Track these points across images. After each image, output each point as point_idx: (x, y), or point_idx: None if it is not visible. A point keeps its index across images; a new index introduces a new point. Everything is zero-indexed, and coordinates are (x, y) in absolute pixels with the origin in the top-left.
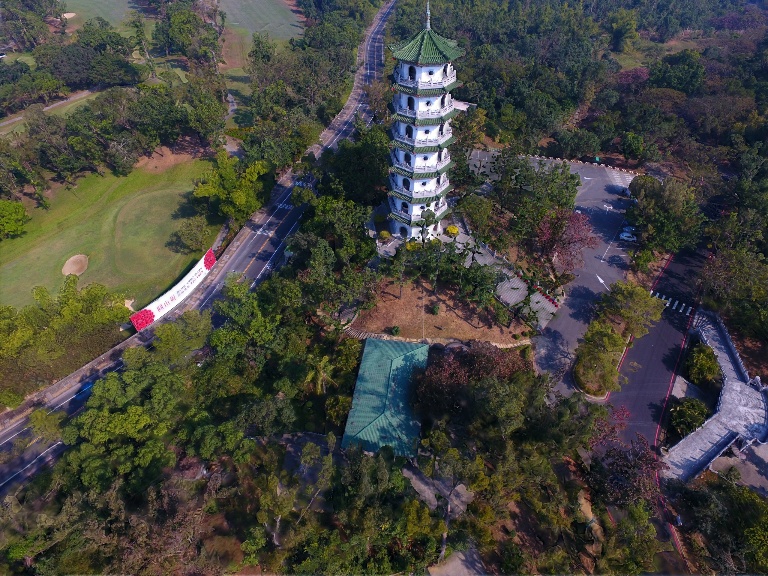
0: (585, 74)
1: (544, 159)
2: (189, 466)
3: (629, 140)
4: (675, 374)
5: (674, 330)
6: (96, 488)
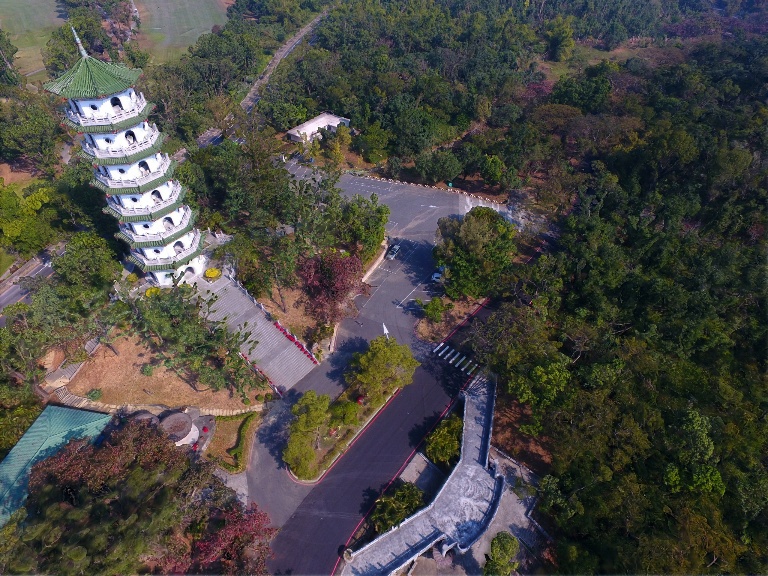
0: (479, 88)
1: (397, 183)
2: None
3: (486, 164)
4: (416, 450)
5: (443, 393)
6: None
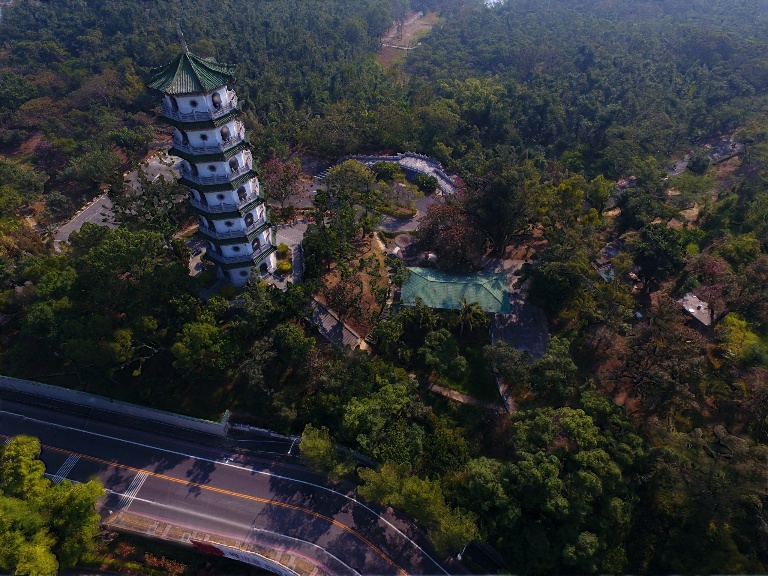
0: None
1: (103, 196)
2: None
3: (124, 135)
4: None
5: None
6: (641, 440)
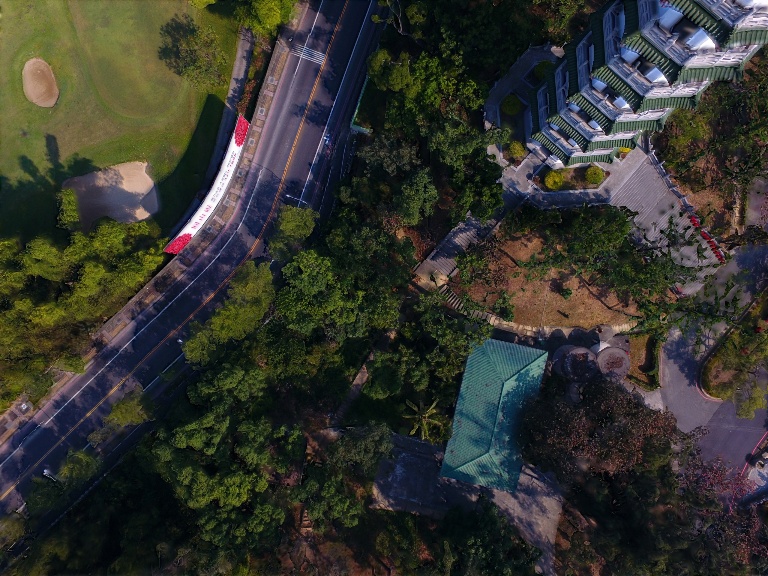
0: None
1: None
2: (289, 474)
3: None
4: None
5: None
6: None
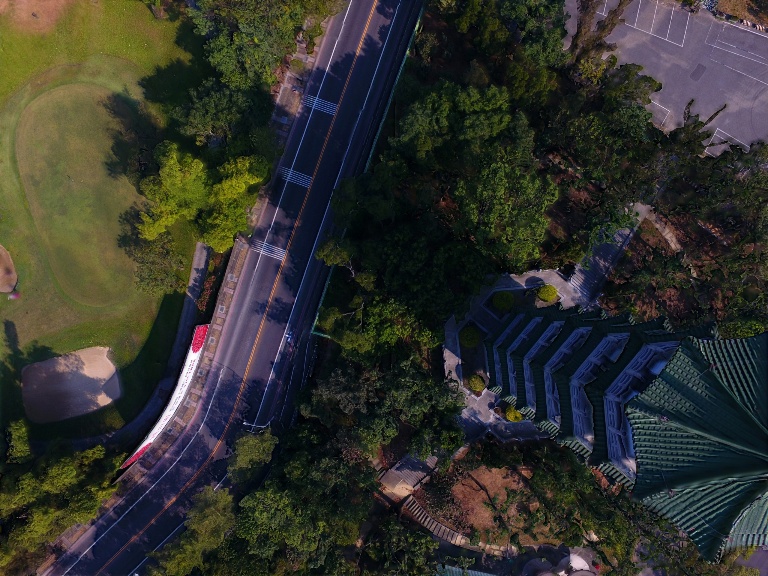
0: None
1: None
2: None
3: None
4: None
5: None
6: None
